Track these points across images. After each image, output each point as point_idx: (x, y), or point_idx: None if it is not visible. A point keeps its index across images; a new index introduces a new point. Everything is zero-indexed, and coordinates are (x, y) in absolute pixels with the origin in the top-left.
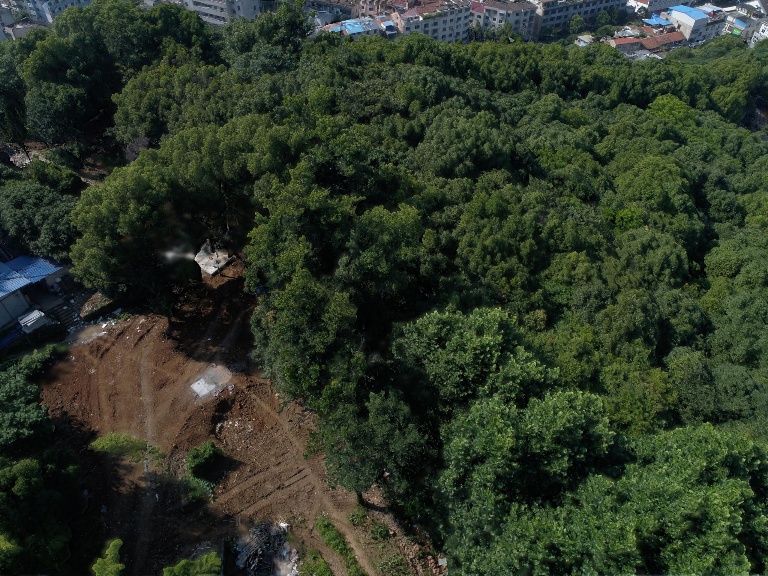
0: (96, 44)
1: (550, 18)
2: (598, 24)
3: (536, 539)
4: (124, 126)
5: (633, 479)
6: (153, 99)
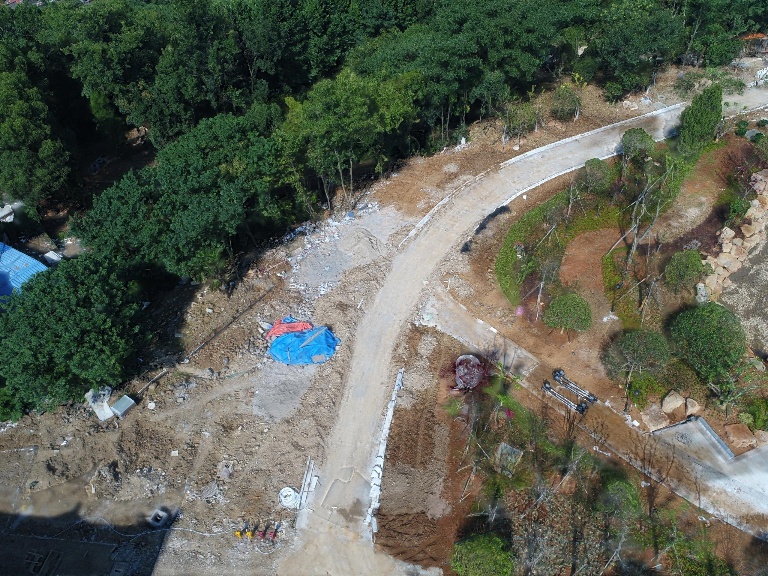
0: None
1: None
2: None
3: (316, 8)
4: None
5: None
6: None
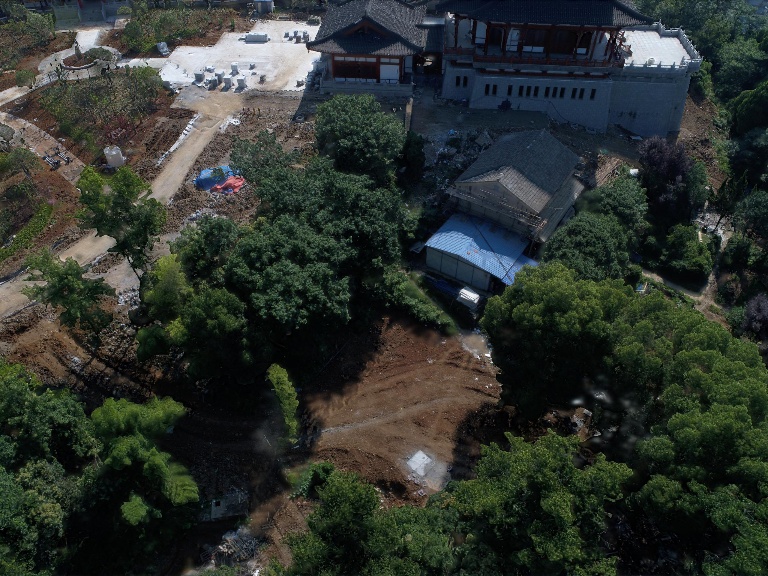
0: None
1: None
2: None
3: None
4: None
5: None
6: None
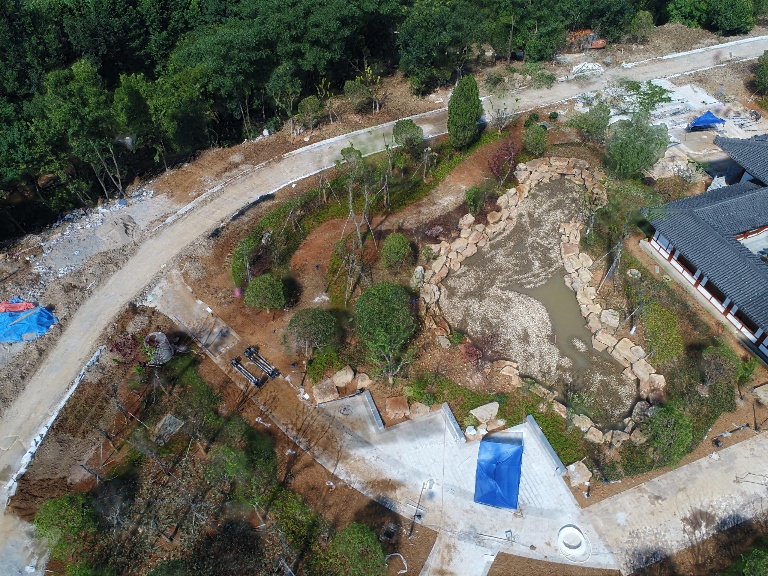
0: None
1: None
2: None
3: (153, 4)
4: None
5: None
6: None
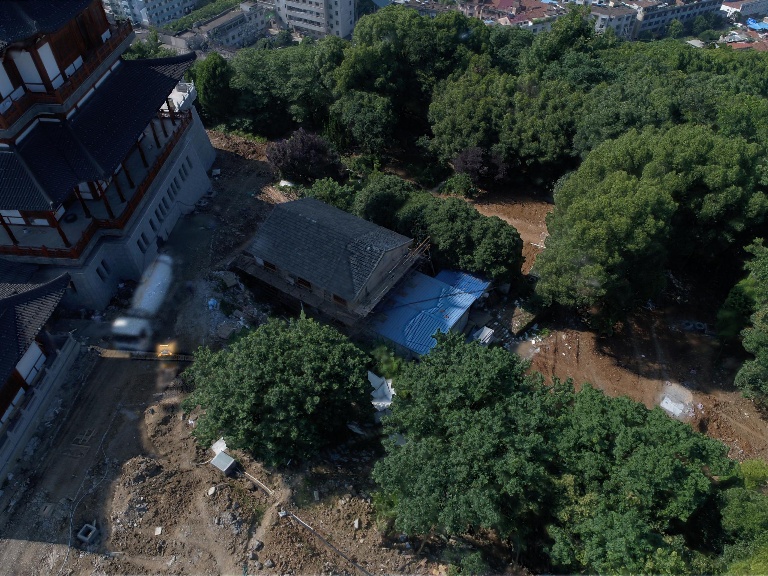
0: (398, 52)
1: (649, 23)
2: (699, 29)
3: None
4: (449, 136)
5: None
6: (486, 108)
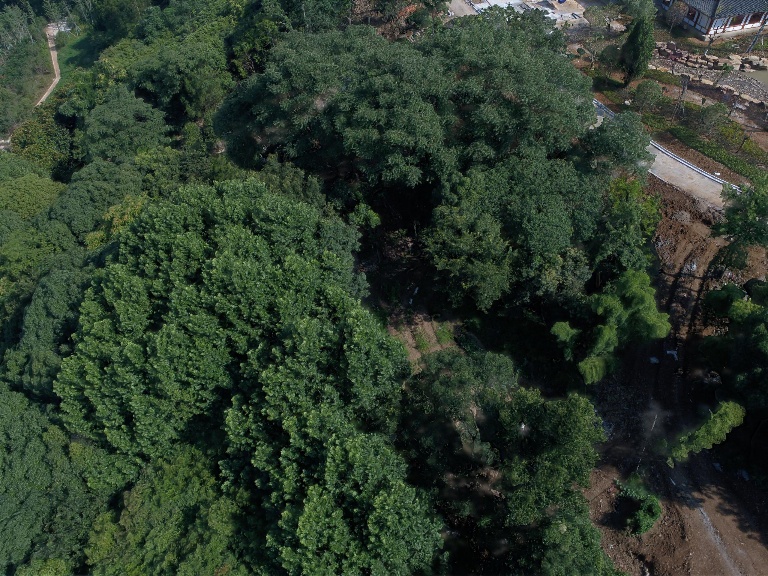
0: None
1: None
2: None
3: (343, 298)
4: None
5: (256, 310)
6: None
